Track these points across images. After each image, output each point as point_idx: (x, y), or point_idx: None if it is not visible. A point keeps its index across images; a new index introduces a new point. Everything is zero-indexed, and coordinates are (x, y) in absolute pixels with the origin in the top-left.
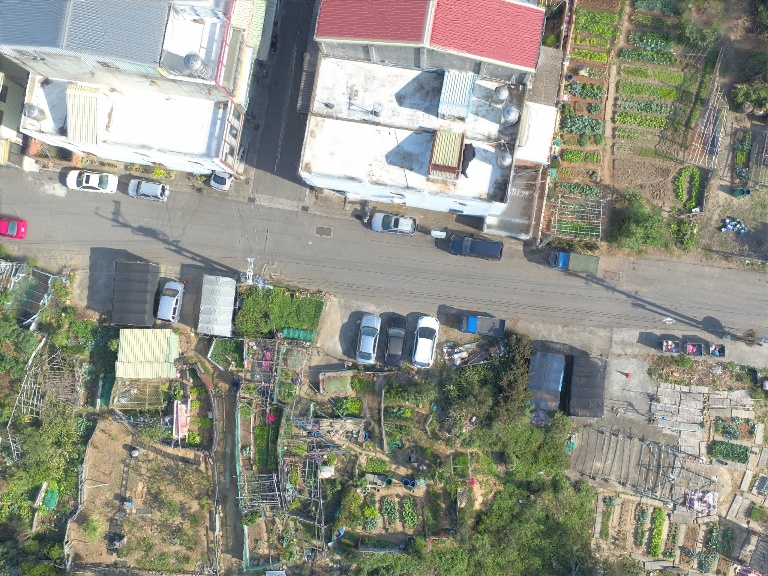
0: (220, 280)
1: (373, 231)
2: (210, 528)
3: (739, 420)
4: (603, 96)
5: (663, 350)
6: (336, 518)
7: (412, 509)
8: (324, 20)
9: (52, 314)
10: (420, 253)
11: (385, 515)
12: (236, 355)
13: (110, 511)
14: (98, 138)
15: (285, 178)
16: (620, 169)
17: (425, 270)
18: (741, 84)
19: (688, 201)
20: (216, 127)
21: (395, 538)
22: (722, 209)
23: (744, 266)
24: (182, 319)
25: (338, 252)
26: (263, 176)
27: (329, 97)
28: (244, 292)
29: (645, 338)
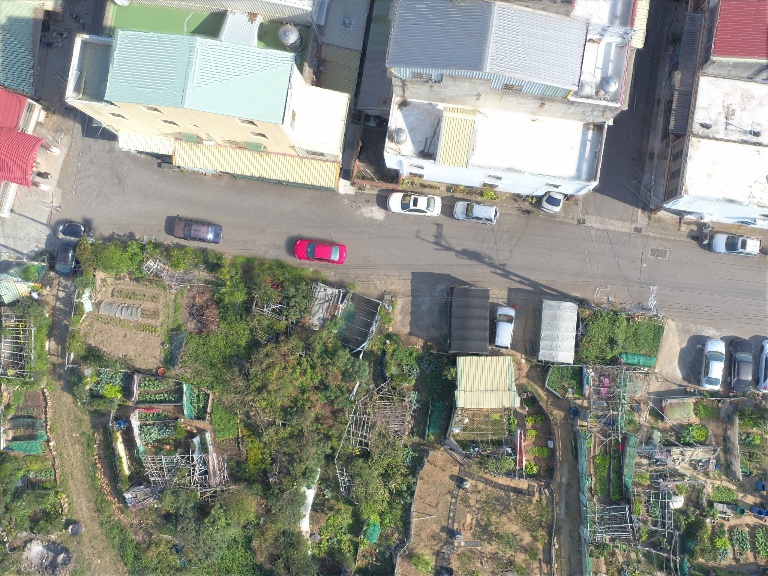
0: (562, 305)
1: (711, 252)
2: (543, 560)
3: None
4: None
5: None
6: (693, 550)
7: (764, 539)
8: (721, 38)
9: (375, 341)
10: (761, 274)
11: (736, 545)
12: (573, 382)
13: (436, 544)
14: (469, 162)
15: (616, 198)
16: None
17: (767, 292)
18: None
19: None
20: (586, 149)
21: (746, 569)
22: None
23: None
24: (512, 345)
25: (674, 274)
26: (592, 197)
27: (705, 117)
28: (588, 317)
29: None
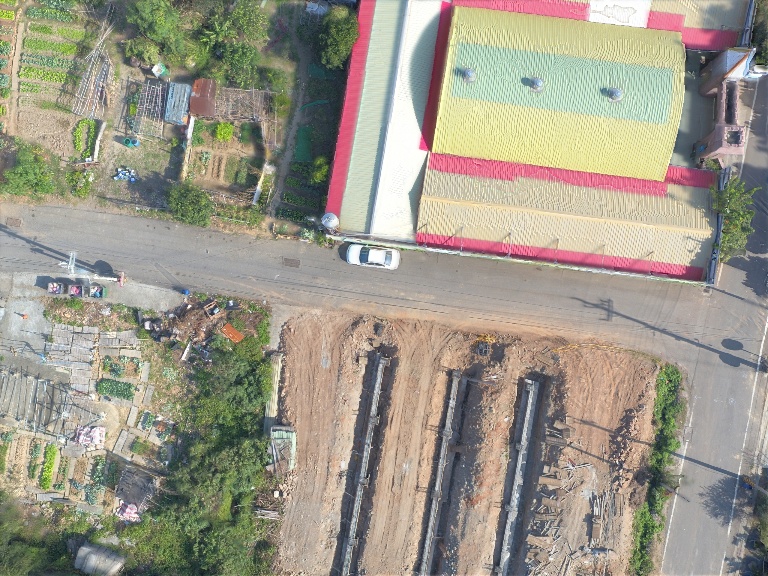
0: None
1: None
2: None
3: (124, 359)
4: (10, 52)
5: (48, 292)
6: None
7: None
8: None
9: None
10: None
11: None
12: None
13: None
14: None
15: None
16: (24, 121)
17: None
18: (127, 39)
19: (84, 151)
20: None
21: None
22: (117, 159)
23: (134, 213)
24: None
25: None
26: None
27: None
28: None
29: (42, 281)
